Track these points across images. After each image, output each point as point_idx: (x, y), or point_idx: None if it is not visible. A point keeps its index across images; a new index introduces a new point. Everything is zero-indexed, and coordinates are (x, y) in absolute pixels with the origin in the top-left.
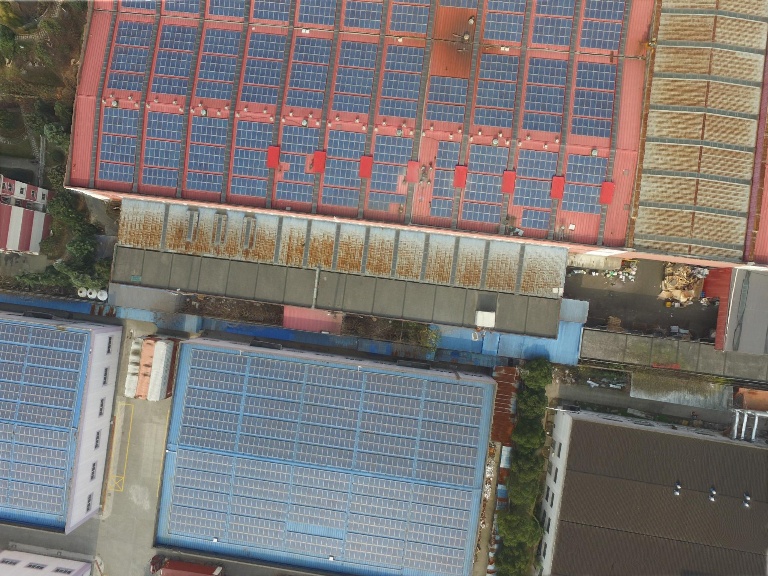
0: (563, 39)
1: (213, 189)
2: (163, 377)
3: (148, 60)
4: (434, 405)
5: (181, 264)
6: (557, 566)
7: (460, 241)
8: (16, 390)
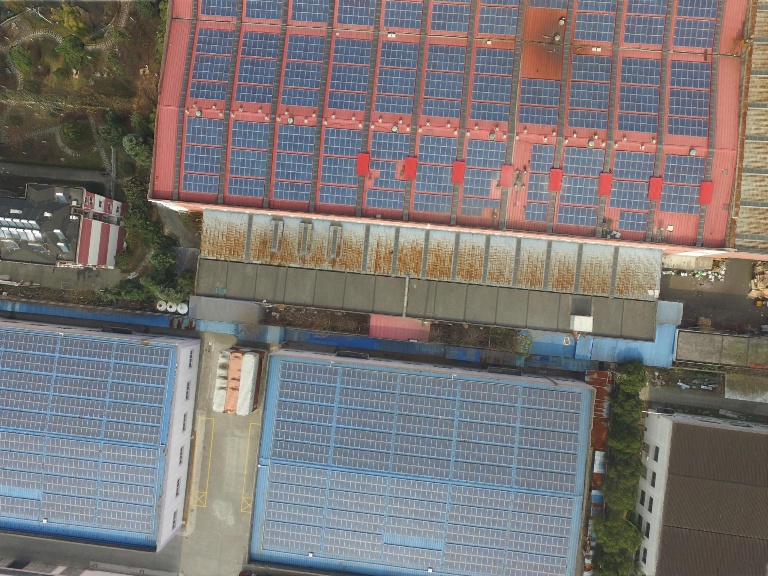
0: (656, 38)
1: (301, 198)
2: (251, 390)
3: (231, 68)
4: (531, 412)
5: (266, 275)
6: (661, 572)
7: (552, 245)
8: (101, 408)
